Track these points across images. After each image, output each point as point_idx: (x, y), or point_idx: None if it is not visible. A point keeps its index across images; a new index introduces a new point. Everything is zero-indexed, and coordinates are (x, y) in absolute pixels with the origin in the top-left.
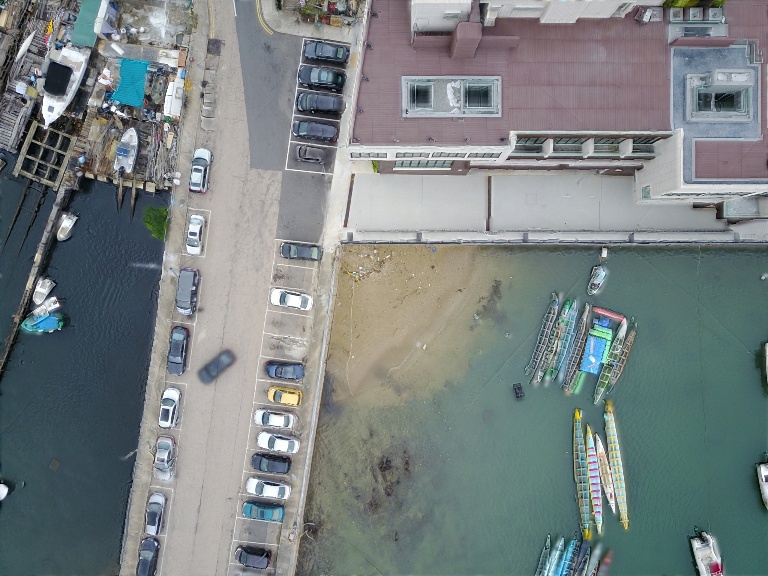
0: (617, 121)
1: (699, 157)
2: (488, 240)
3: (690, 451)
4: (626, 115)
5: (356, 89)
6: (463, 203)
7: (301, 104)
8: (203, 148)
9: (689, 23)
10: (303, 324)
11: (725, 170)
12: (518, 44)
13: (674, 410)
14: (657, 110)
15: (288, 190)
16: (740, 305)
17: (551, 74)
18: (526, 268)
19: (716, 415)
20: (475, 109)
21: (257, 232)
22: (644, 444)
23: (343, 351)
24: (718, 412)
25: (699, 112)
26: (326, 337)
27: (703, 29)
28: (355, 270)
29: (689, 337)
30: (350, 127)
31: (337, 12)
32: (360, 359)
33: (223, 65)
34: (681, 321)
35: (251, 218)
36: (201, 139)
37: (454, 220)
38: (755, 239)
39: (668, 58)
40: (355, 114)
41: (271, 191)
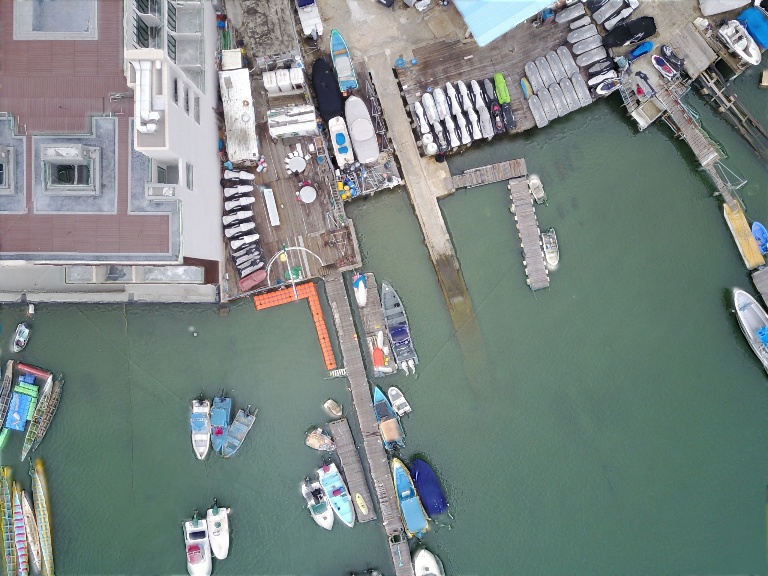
0: None
1: None
2: None
3: (119, 508)
4: None
5: None
6: None
7: None
8: None
9: None
10: None
11: None
12: None
13: (105, 467)
14: None
15: None
16: (175, 361)
17: None
18: None
19: (148, 472)
20: None
21: None
22: (76, 501)
23: None
24: (150, 469)
25: None
26: None
27: None
28: None
29: (120, 394)
30: None
31: None
32: None
33: None
34: (113, 378)
35: None
36: None
37: None
38: (147, 300)
39: None
40: None
41: None
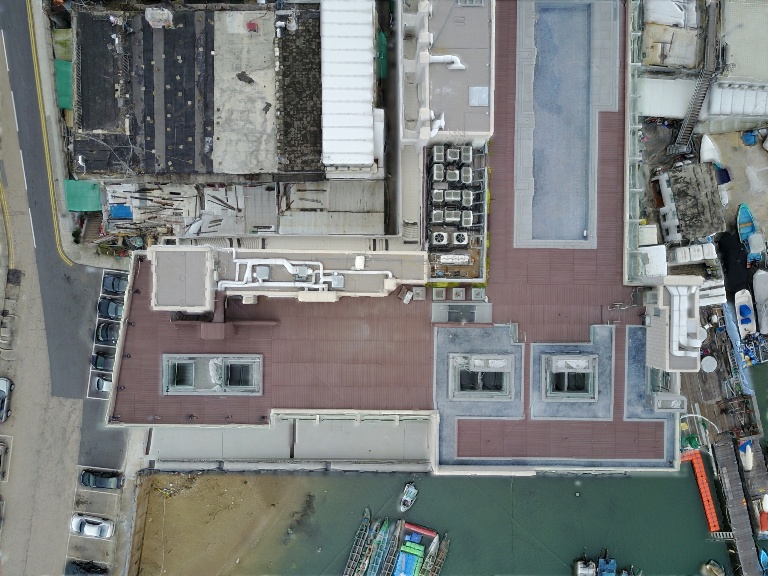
0: (380, 399)
1: (461, 436)
2: (289, 470)
3: None
4: (389, 393)
5: (116, 367)
6: (267, 430)
7: (102, 334)
8: (3, 377)
9: (452, 302)
10: (106, 548)
11: (487, 449)
12: (281, 322)
13: None
14: (420, 388)
15: (90, 418)
16: (555, 520)
17: (314, 351)
18: (341, 482)
19: None
20: (236, 387)
21: (59, 458)
22: None
23: (155, 566)
24: None
25: (460, 392)
26: (129, 561)
27: (467, 307)
28: (166, 487)
29: (503, 553)
30: (110, 405)
31: (135, 247)
32: (172, 573)
33: (23, 295)
34: (495, 536)
35: (53, 444)
36: (2, 367)
37: (257, 447)
38: None
39: (431, 336)
40: (116, 390)
41: (73, 418)
